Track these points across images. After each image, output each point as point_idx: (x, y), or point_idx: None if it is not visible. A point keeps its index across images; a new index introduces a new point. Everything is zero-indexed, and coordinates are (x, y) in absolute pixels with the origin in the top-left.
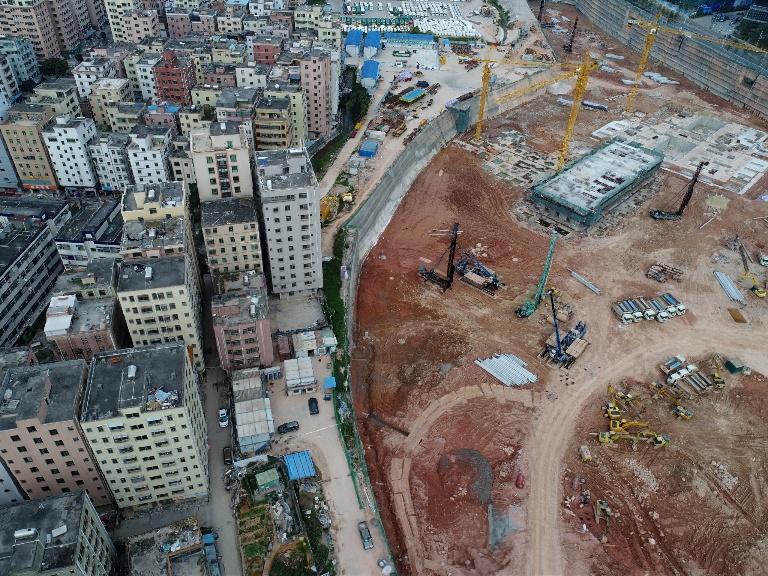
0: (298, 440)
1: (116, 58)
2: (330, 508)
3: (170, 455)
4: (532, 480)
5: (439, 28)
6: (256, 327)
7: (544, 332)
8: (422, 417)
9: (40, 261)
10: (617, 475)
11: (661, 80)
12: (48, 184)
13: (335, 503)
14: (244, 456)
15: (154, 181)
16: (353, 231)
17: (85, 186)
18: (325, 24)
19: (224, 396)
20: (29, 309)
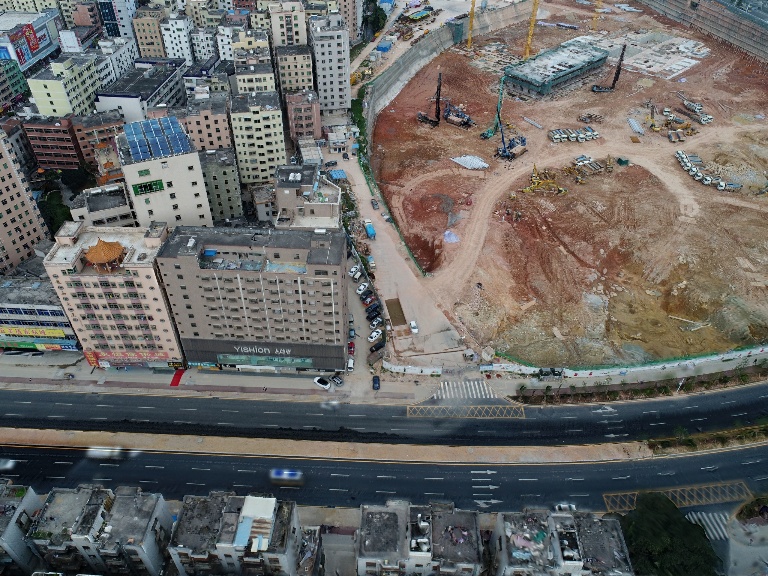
0: None
1: None
2: (355, 195)
3: (271, 145)
4: (477, 204)
5: None
6: (312, 108)
7: None
8: (413, 181)
9: (173, 92)
10: (531, 206)
11: (628, 9)
12: None
13: (358, 194)
14: None
15: None
16: (371, 86)
17: None
18: None
19: (292, 154)
20: None
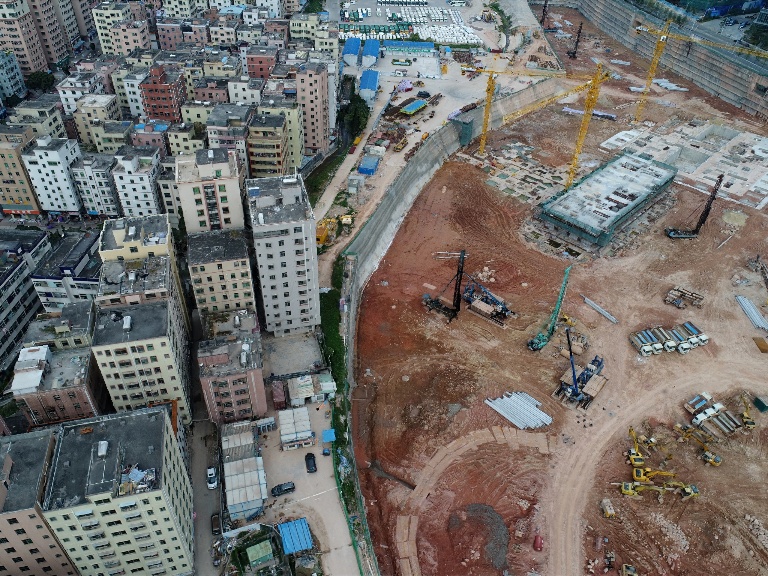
0: (294, 504)
1: (103, 72)
2: None
3: (148, 539)
4: (551, 541)
5: (440, 35)
6: (247, 377)
7: (558, 366)
8: (429, 467)
9: (16, 299)
10: (643, 532)
11: (669, 87)
12: (30, 209)
13: None
14: (234, 524)
15: (142, 205)
16: (353, 258)
17: (69, 210)
18: (322, 34)
19: (213, 452)
20: (4, 351)
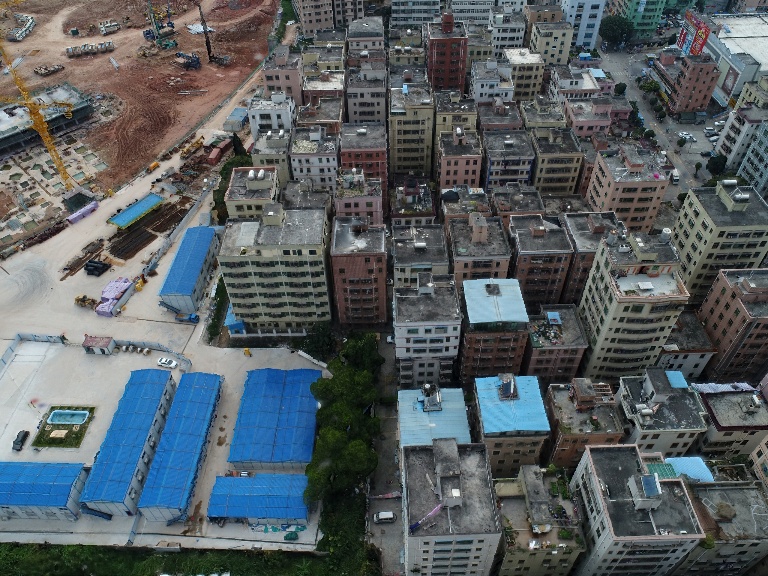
0: None
1: None
2: None
3: None
4: None
5: None
6: None
7: None
8: None
9: None
10: None
11: None
12: None
13: None
14: None
15: None
16: None
17: None
18: None
19: None
20: None
